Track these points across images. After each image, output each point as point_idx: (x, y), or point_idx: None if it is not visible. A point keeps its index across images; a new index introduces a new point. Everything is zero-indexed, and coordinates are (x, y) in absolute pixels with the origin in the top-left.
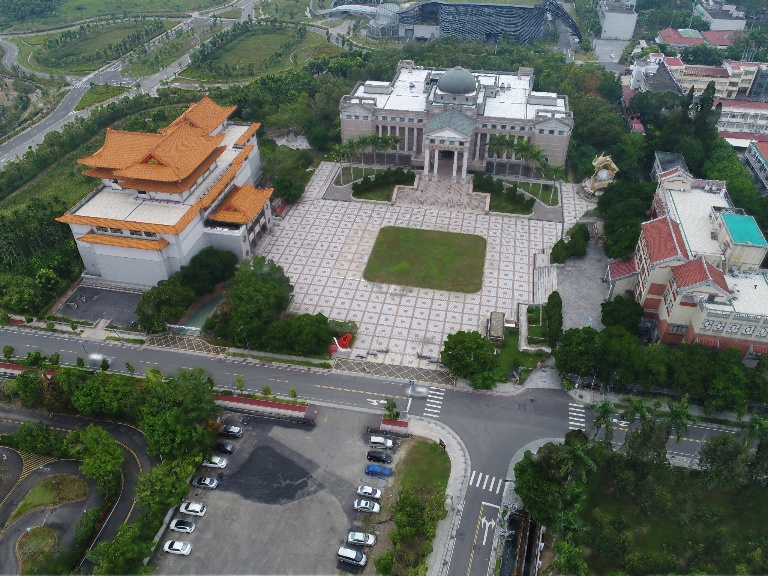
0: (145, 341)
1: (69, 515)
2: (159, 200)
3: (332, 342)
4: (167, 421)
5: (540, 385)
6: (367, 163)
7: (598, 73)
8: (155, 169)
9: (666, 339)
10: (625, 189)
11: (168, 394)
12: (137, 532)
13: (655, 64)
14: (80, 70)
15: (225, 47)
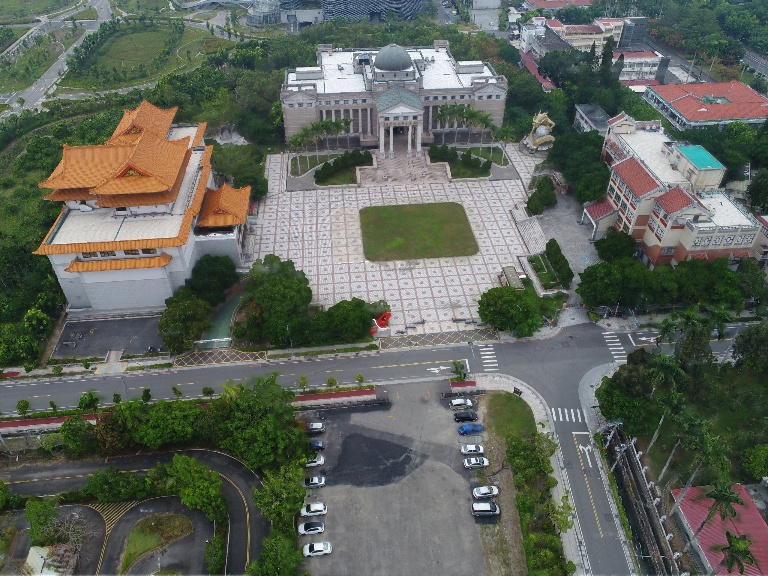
0: (172, 363)
1: (184, 552)
2: (142, 214)
3: (372, 324)
4: (269, 429)
5: (571, 323)
6: (314, 150)
7: (491, 40)
8: (136, 181)
9: (659, 262)
10: (574, 139)
11: (254, 404)
12: (286, 542)
13: (542, 27)
14: None
15: (98, 50)
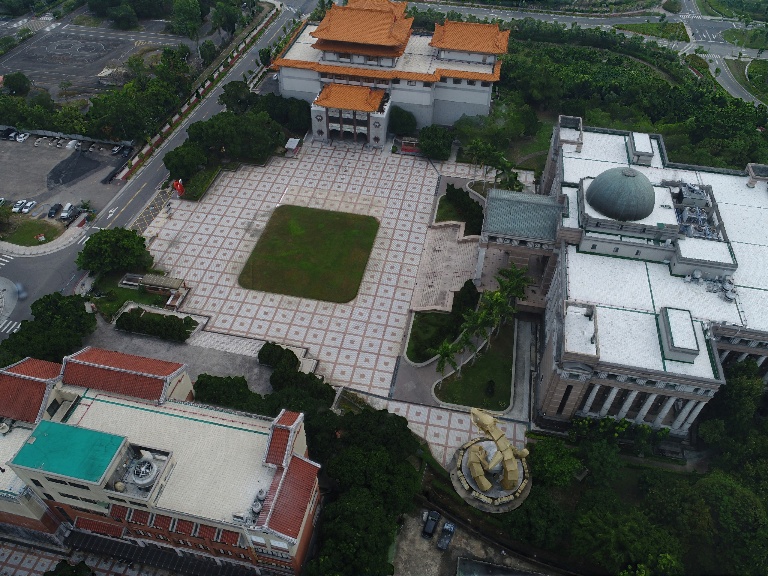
0: None
1: None
2: None
3: None
4: None
5: None
6: None
7: None
8: None
9: None
10: (360, 420)
11: None
12: (35, 112)
13: None
14: (717, 10)
15: None
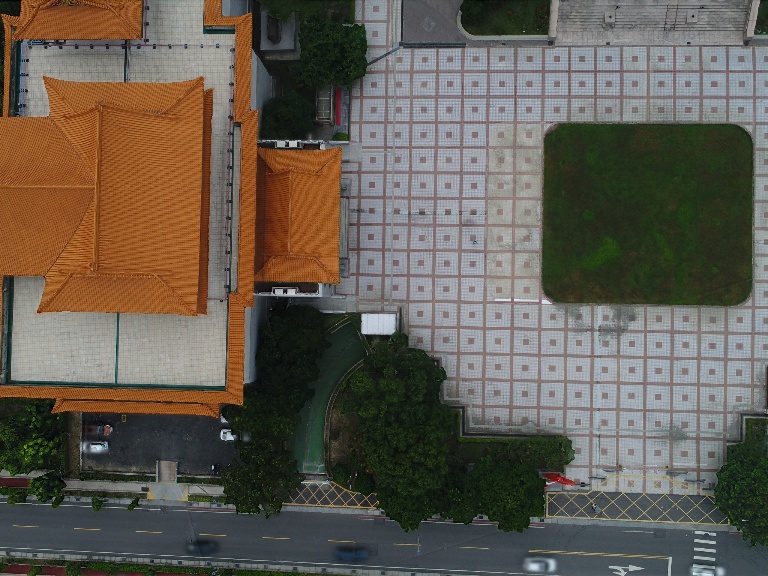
0: None
1: None
2: None
3: None
4: None
5: None
6: None
7: None
8: (122, 286)
9: None
10: None
11: None
12: None
13: None
14: None
15: None
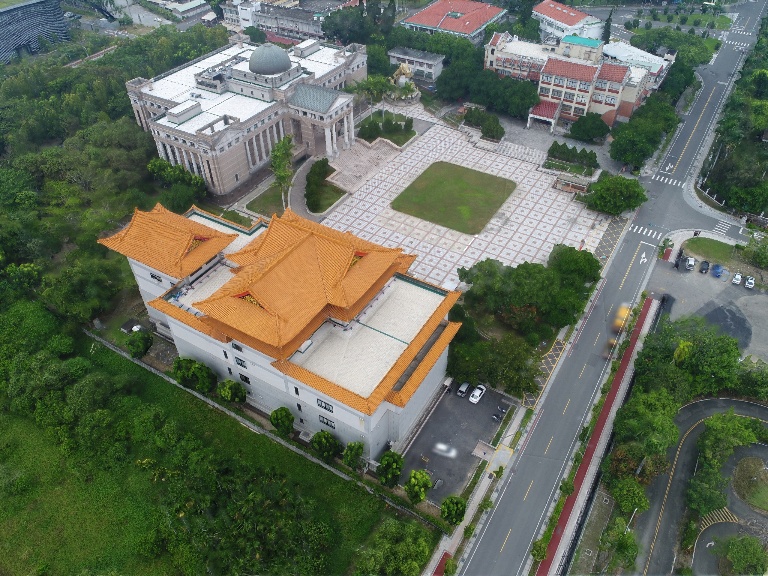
0: None
1: None
2: (366, 306)
3: None
4: None
5: None
6: (248, 191)
7: None
8: (364, 267)
9: None
10: (462, 71)
11: (701, 340)
12: None
13: (254, 2)
14: None
15: None
